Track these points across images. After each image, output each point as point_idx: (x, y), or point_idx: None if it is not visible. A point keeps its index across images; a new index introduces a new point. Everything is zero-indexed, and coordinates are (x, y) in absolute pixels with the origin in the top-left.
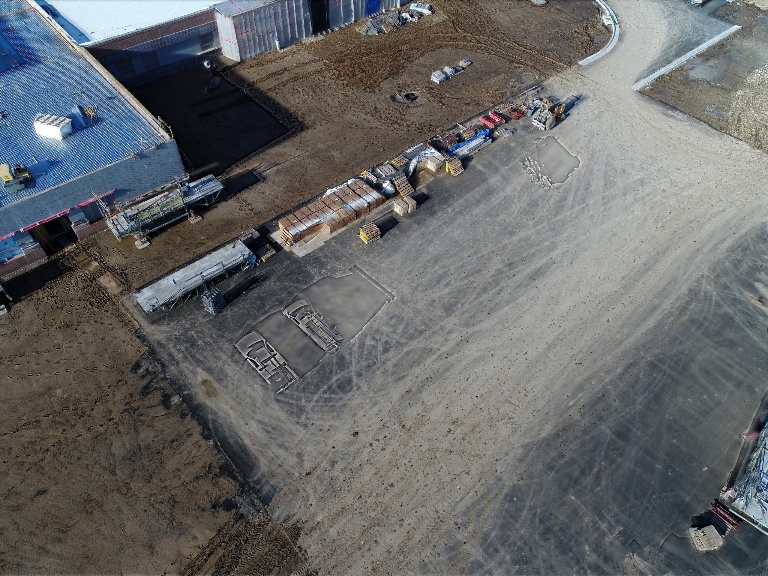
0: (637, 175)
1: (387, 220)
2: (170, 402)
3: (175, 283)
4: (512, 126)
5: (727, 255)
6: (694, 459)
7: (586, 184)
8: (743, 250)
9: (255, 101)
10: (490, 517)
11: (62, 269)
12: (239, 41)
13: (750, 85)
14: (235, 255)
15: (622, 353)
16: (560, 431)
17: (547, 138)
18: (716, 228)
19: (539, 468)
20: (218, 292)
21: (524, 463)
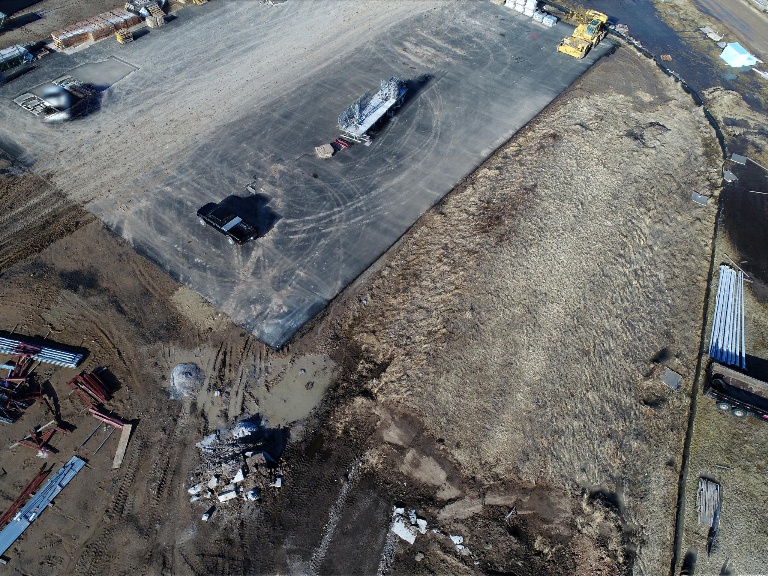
0: None
1: (141, 31)
2: None
3: None
4: None
5: (389, 30)
6: (331, 123)
7: (300, 2)
8: (402, 27)
9: None
10: (186, 158)
11: None
12: None
13: None
14: None
15: (298, 81)
16: (244, 118)
17: None
18: (387, 17)
19: (225, 135)
20: None
21: (215, 134)
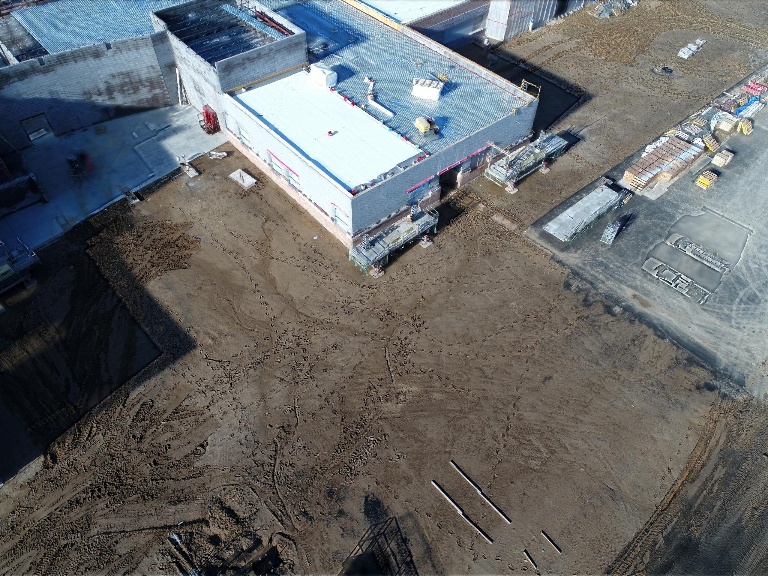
0: None
1: None
2: (613, 311)
3: (572, 218)
4: None
5: None
6: None
7: None
8: None
9: (535, 74)
10: None
11: (457, 210)
12: (508, 22)
13: None
14: (608, 197)
15: None
16: None
17: None
18: None
19: None
20: None
21: None
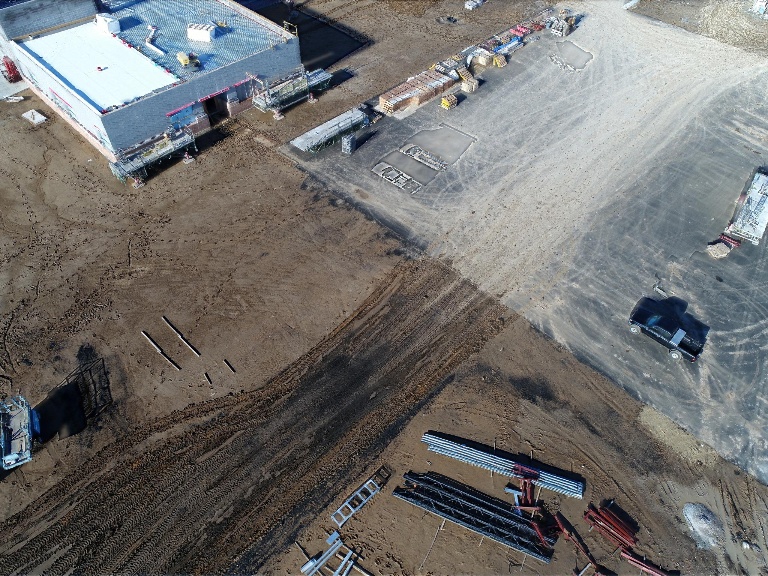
0: (637, 62)
1: (458, 96)
2: (336, 203)
3: (318, 134)
4: (536, 35)
5: (710, 106)
6: (705, 215)
7: (600, 69)
8: (721, 103)
9: (331, 26)
10: (576, 248)
11: (225, 134)
12: None
13: (712, 3)
14: (355, 117)
15: (646, 162)
16: (612, 204)
17: (565, 42)
18: (700, 91)
19: (603, 223)
20: (354, 135)
21: (592, 221)
